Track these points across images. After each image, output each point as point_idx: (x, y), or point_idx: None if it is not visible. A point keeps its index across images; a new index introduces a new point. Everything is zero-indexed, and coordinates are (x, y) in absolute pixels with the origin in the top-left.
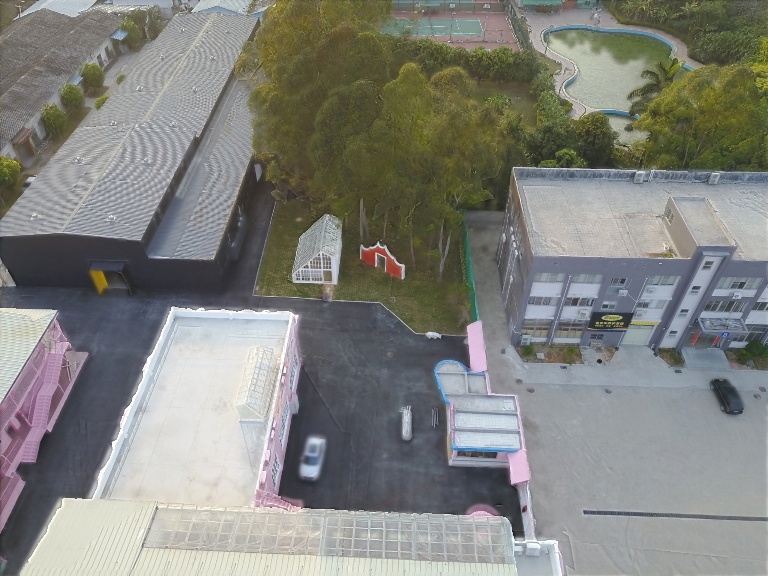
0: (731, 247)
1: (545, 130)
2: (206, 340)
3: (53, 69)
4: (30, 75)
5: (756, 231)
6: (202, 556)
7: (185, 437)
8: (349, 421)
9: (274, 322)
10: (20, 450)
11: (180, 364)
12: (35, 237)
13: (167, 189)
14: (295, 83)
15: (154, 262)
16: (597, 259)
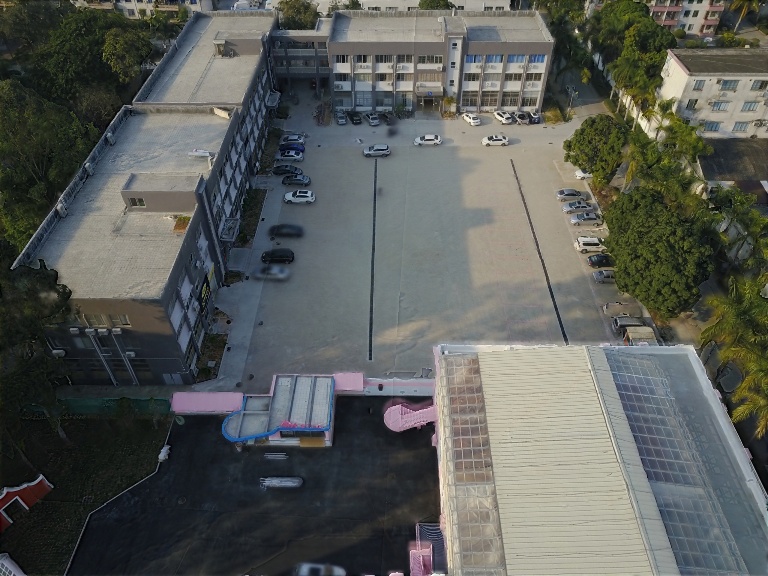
0: (201, 176)
1: None
2: None
3: None
4: None
5: (167, 168)
6: None
7: None
8: (272, 543)
9: None
10: None
11: None
12: None
13: None
14: None
15: None
16: (178, 257)
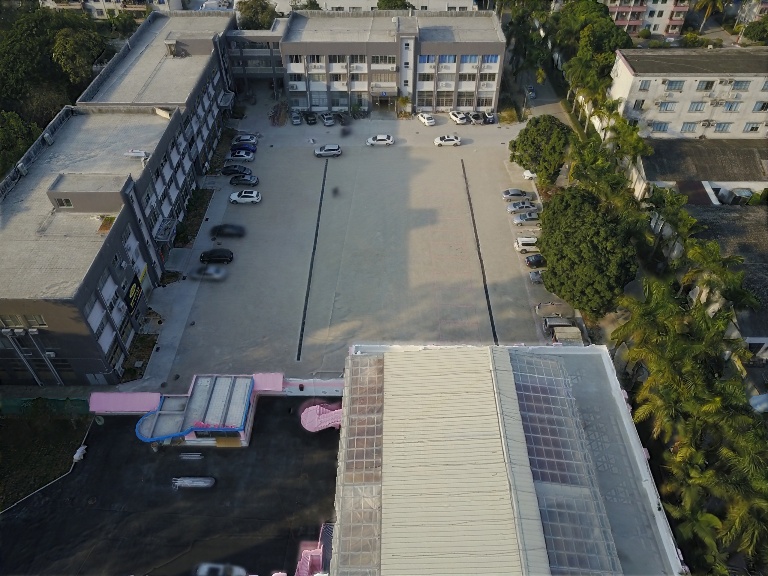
0: (129, 176)
1: None
2: None
3: None
4: None
5: (101, 169)
6: None
7: None
8: (177, 543)
9: None
10: None
11: None
12: None
13: None
14: None
15: None
16: (97, 258)
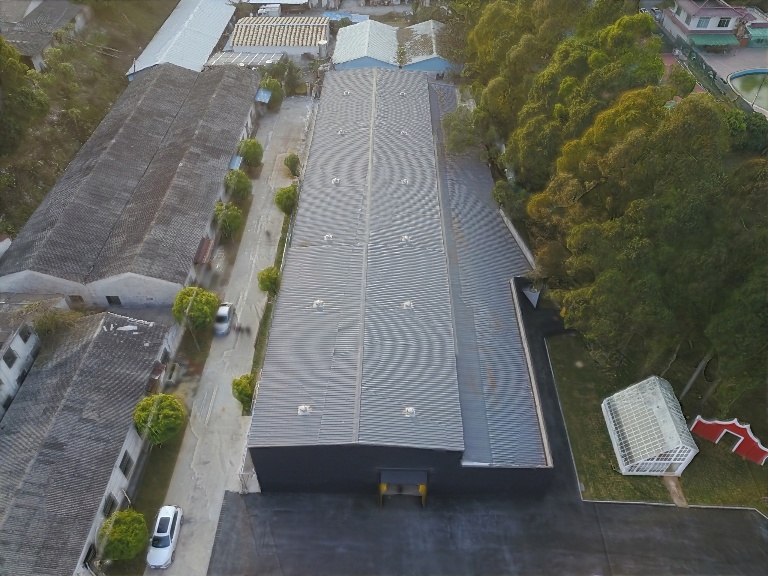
0: None
1: None
2: None
3: (210, 149)
4: (188, 160)
5: None
6: None
7: None
8: None
9: None
10: None
11: None
12: (318, 448)
13: (454, 352)
14: (687, 231)
15: (469, 471)
16: None
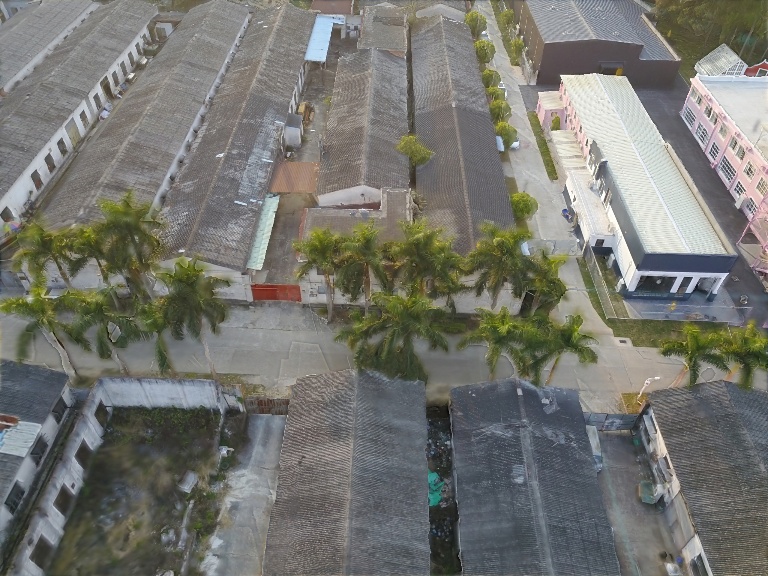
0: None
1: None
2: (729, 89)
3: None
4: None
5: None
6: None
7: (764, 123)
8: None
9: (761, 82)
10: None
11: (726, 98)
12: (578, 42)
13: None
14: None
15: (643, 63)
16: None
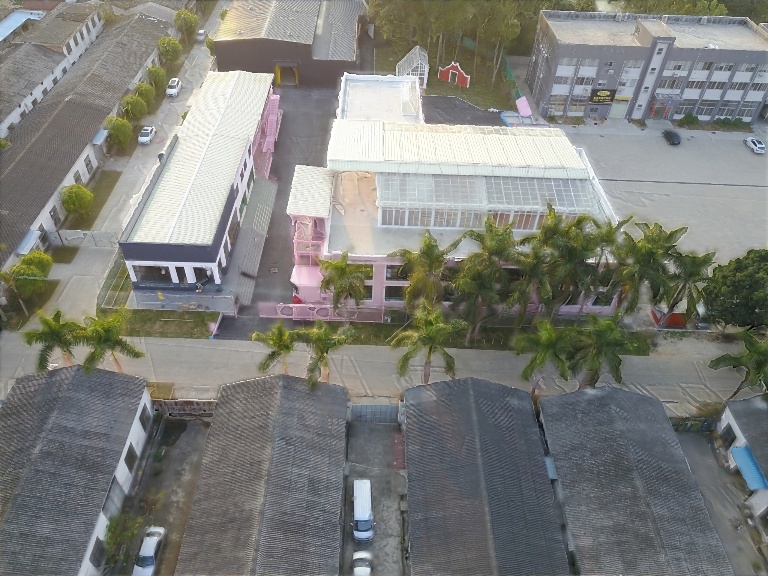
0: (673, 37)
1: (555, 3)
2: (369, 88)
3: None
4: None
5: (688, 42)
6: (415, 133)
7: None
8: None
9: None
10: (265, 144)
11: (358, 96)
12: (245, 40)
13: None
14: None
15: (317, 62)
16: (597, 46)
